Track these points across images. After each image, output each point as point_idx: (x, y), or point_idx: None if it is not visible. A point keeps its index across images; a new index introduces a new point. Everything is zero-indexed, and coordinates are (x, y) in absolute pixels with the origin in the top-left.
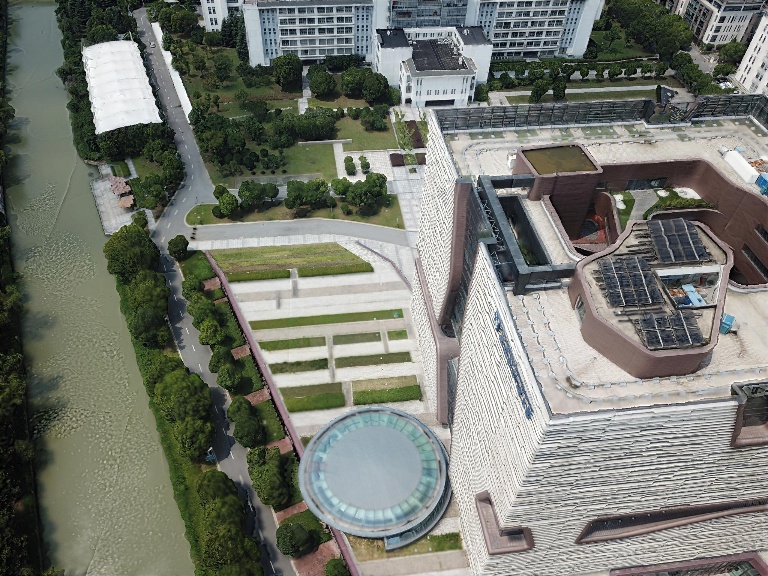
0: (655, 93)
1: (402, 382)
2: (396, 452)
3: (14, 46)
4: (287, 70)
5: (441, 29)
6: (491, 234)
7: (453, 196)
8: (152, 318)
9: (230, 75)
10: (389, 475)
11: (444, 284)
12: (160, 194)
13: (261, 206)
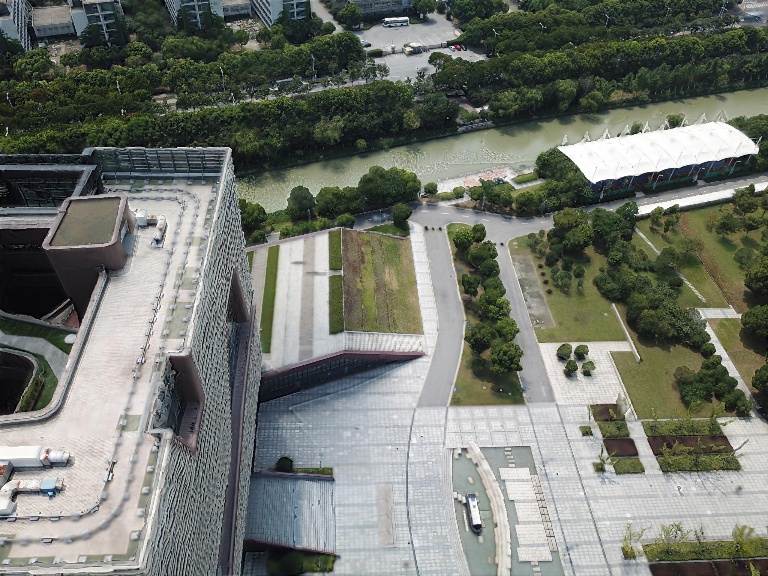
0: None
1: None
2: None
3: (734, 97)
4: (761, 274)
5: None
6: (3, 154)
7: None
8: (298, 195)
9: (759, 242)
10: None
11: None
12: (474, 195)
13: (481, 273)
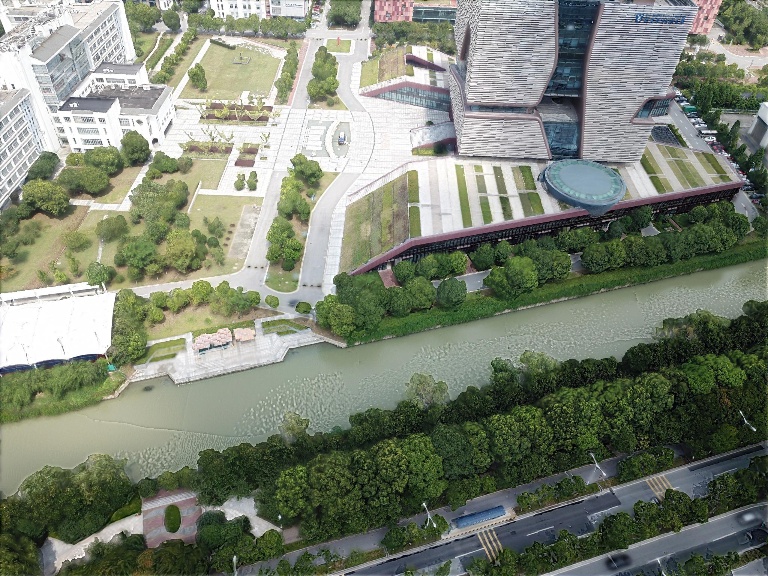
0: (216, 45)
1: (517, 172)
2: (577, 170)
3: None
4: (62, 190)
5: (87, 81)
6: (597, 1)
7: (552, 13)
8: None
9: None
10: (591, 174)
11: (546, 72)
12: None
13: None
